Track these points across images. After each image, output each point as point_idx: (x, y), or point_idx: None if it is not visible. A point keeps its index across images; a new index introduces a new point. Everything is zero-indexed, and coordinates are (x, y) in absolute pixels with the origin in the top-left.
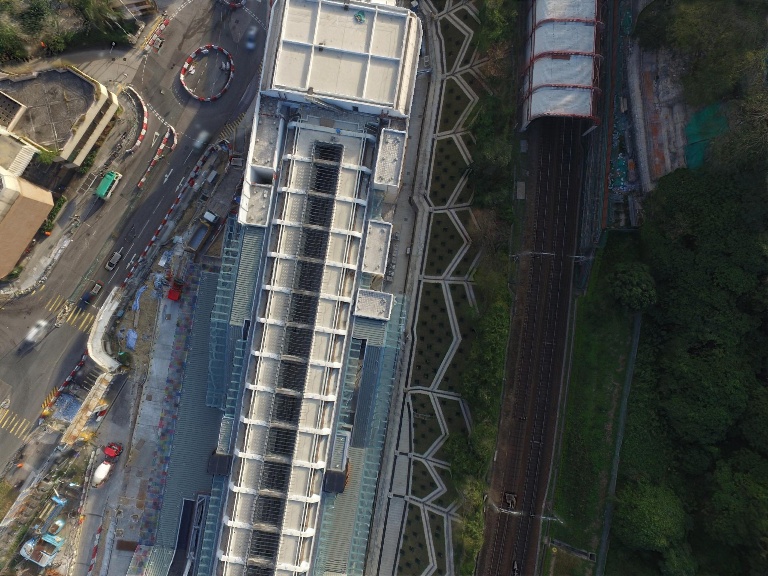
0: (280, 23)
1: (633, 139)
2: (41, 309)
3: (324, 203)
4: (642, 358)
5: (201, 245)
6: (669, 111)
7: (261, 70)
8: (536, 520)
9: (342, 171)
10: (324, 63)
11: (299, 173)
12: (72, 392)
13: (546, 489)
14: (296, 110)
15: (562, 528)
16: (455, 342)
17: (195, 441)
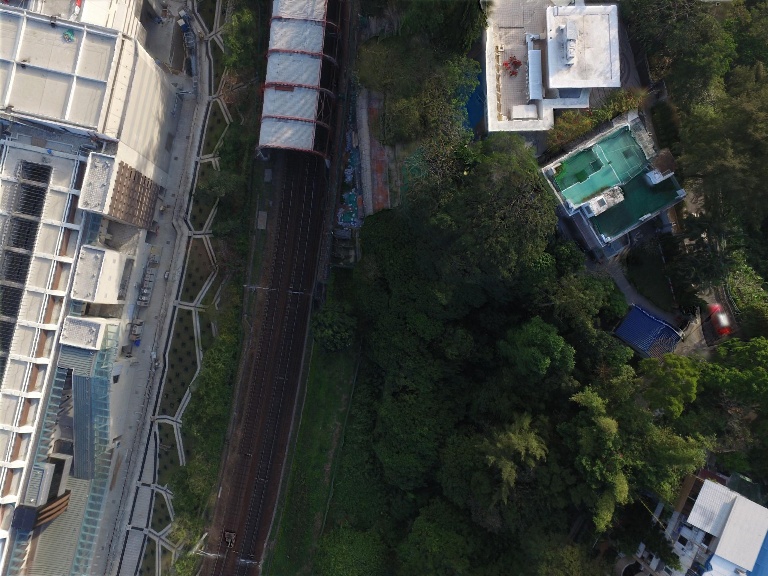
0: None
1: (360, 175)
2: None
3: (26, 226)
4: (360, 398)
5: None
6: (392, 149)
7: None
8: None
9: (51, 193)
10: (27, 81)
11: (5, 193)
12: None
13: (269, 528)
14: None
15: (279, 569)
16: None
17: None
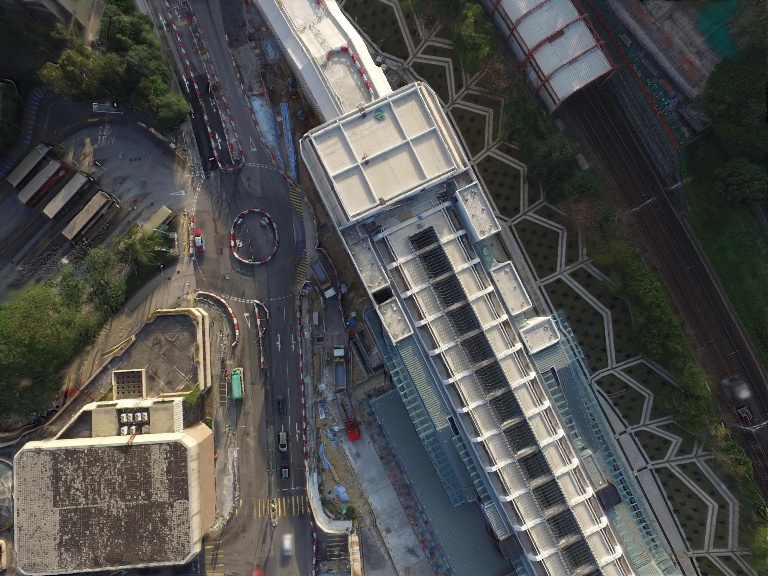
0: (319, 163)
1: (653, 63)
2: (252, 521)
3: (450, 283)
4: None
5: (345, 380)
6: (670, 22)
7: (295, 205)
8: None
9: (445, 247)
10: (376, 172)
11: (411, 272)
12: (324, 569)
13: (765, 385)
14: (373, 223)
15: None
16: (606, 317)
17: (461, 541)
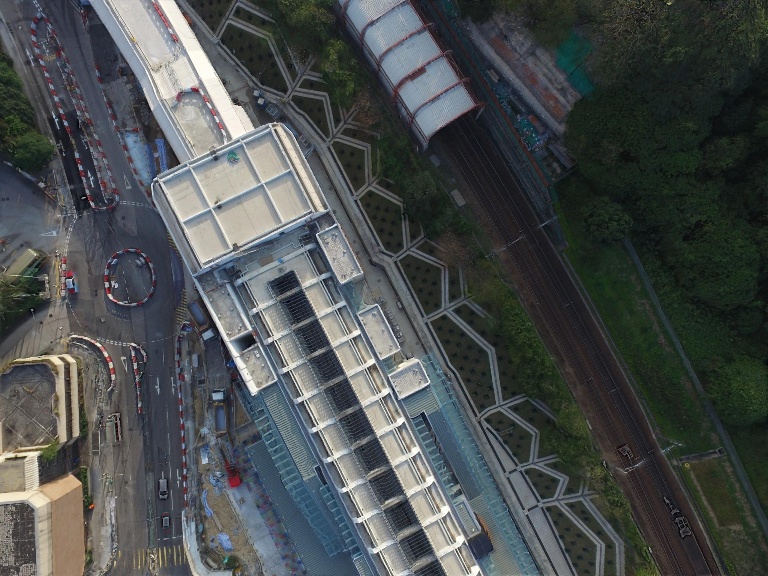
0: (170, 209)
1: (521, 99)
2: (131, 572)
3: (311, 329)
4: (650, 268)
5: (227, 423)
6: (534, 58)
7: (172, 244)
8: (656, 453)
9: (307, 291)
10: (230, 216)
11: (273, 318)
12: None
13: (647, 422)
14: (233, 268)
15: None
16: (491, 354)
17: None
